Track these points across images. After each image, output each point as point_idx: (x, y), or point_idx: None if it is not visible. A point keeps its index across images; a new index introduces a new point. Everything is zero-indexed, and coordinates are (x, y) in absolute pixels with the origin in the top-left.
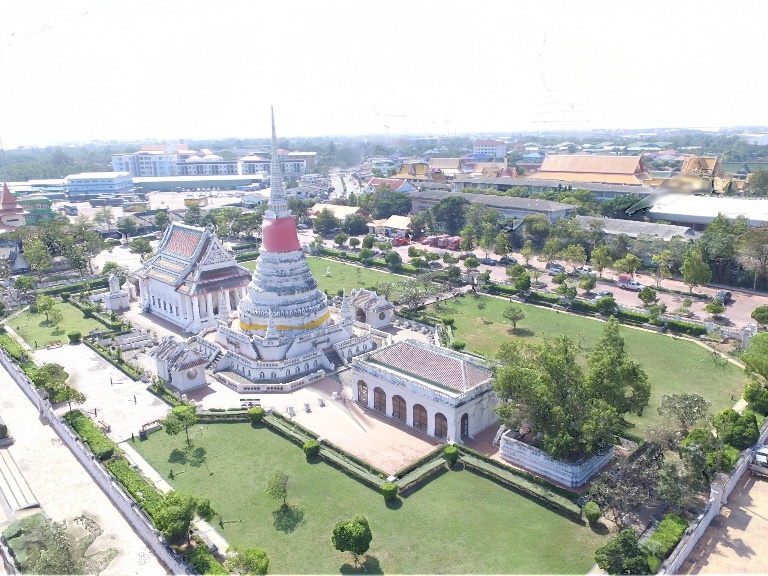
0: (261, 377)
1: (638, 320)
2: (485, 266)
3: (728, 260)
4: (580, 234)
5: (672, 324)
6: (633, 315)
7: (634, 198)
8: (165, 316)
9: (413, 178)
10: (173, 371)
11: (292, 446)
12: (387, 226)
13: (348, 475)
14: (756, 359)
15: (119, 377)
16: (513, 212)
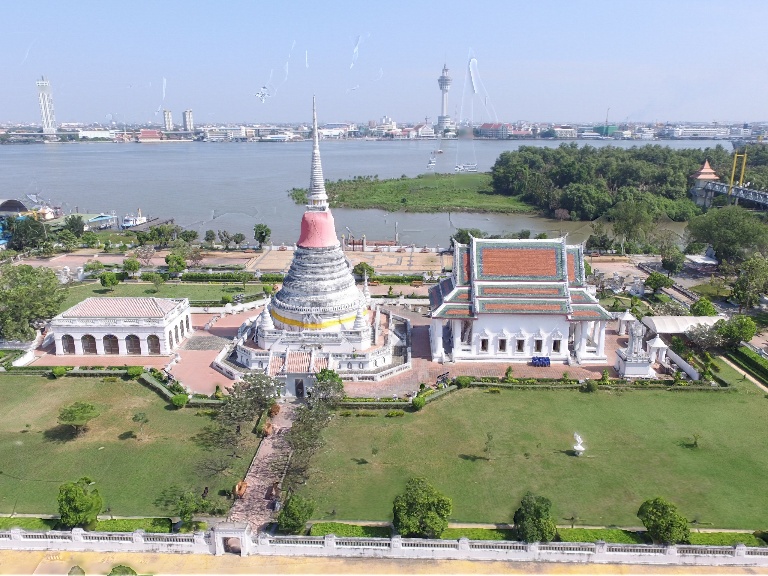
0: None
1: None
2: None
3: None
4: None
5: None
6: None
7: None
8: None
9: None
10: None
11: None
12: None
13: None
14: None
15: None
16: None
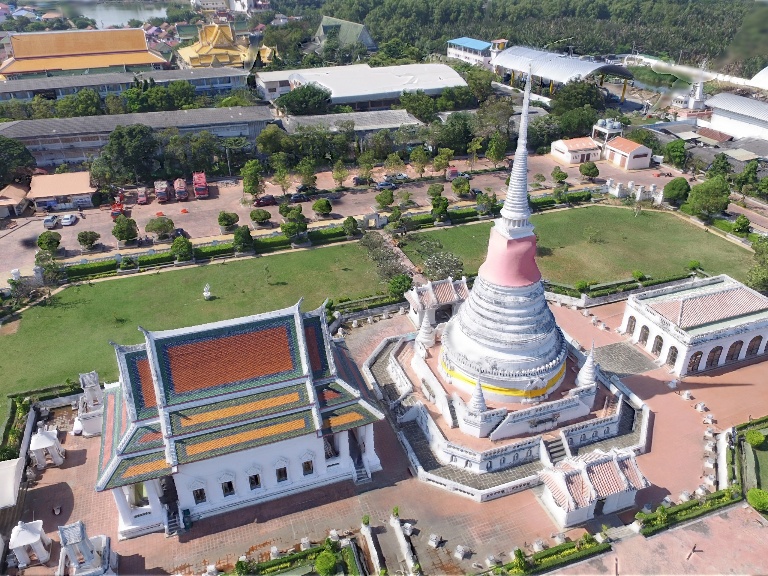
0: None
1: (549, 204)
2: (306, 204)
3: (480, 133)
4: (341, 139)
5: (573, 198)
6: (544, 201)
7: (318, 88)
8: (260, 498)
9: None
10: None
11: None
12: (46, 196)
13: None
14: (713, 201)
15: (590, 571)
16: (211, 129)
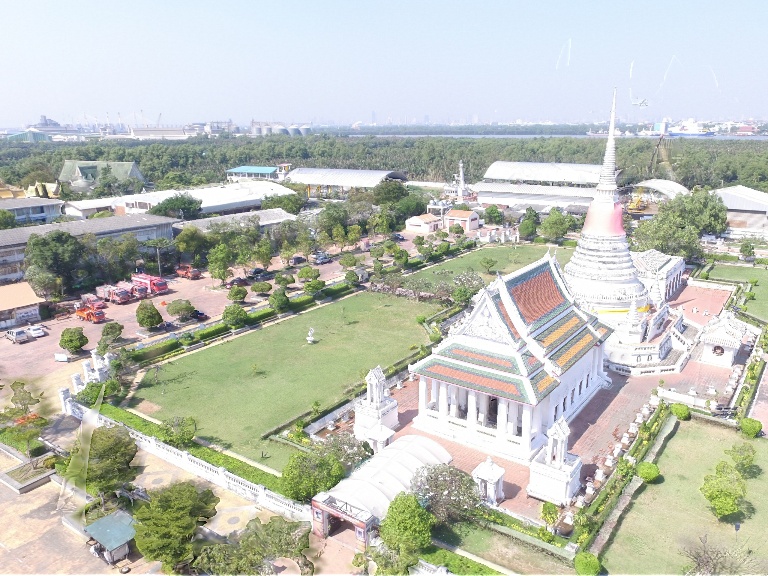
0: None
1: (458, 251)
2: None
3: None
4: (255, 231)
5: None
6: None
7: (191, 196)
8: None
9: None
10: None
11: None
12: None
13: None
14: None
15: None
16: None
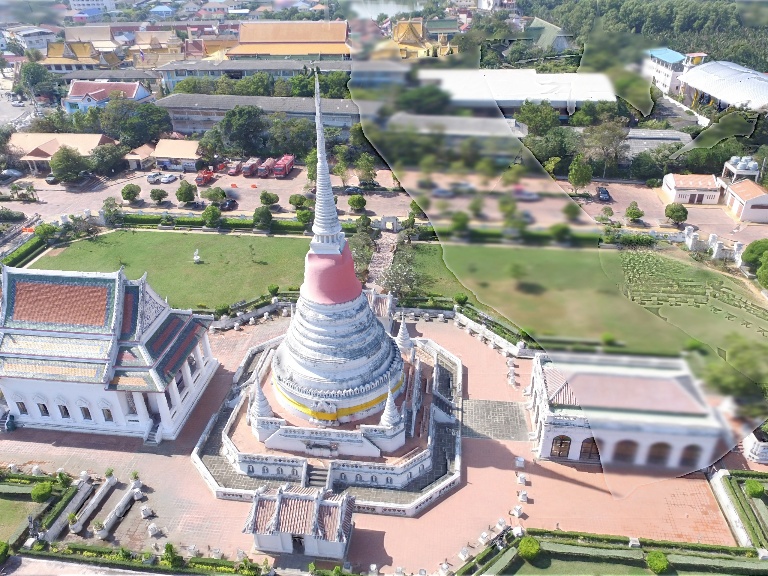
0: (407, 478)
1: None
2: None
3: None
4: None
5: None
6: None
7: None
8: (69, 427)
9: (75, 63)
10: (316, 540)
11: (621, 569)
12: (162, 157)
13: (724, 573)
14: None
15: None
16: None
